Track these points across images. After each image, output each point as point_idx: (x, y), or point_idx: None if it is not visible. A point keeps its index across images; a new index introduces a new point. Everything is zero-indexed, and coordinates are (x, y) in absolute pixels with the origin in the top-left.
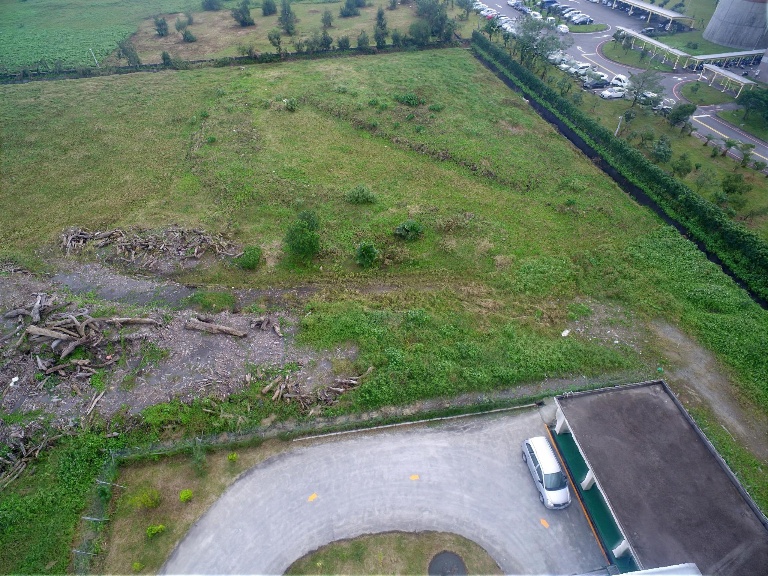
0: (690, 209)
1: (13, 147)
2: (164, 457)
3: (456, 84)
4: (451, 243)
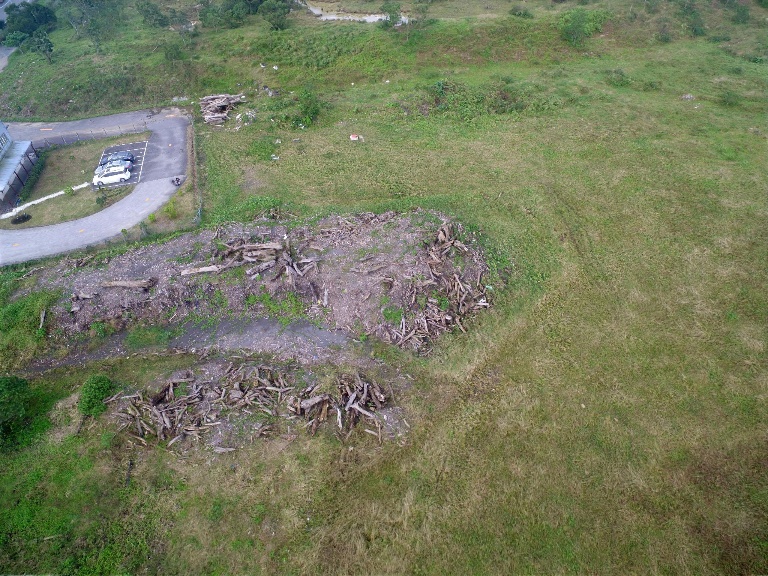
0: None
1: None
2: None
3: None
4: None
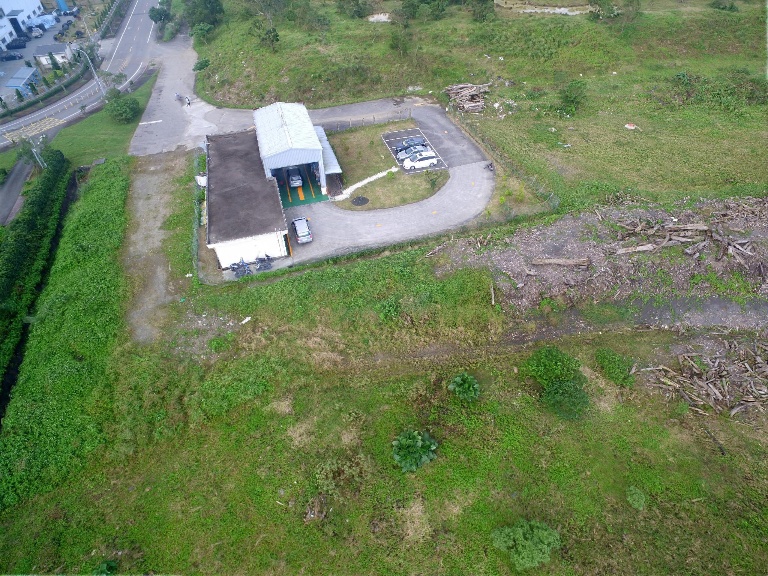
0: None
1: None
2: None
3: None
4: (349, 436)
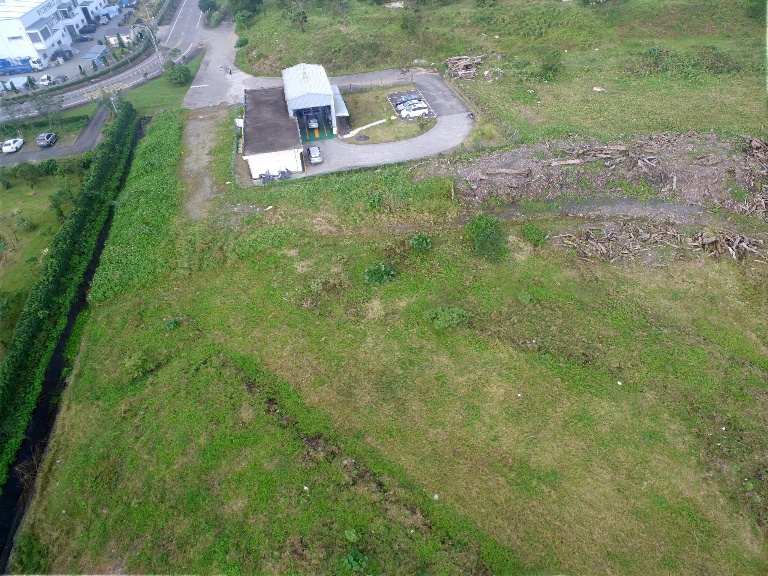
0: (48, 308)
1: None
2: None
3: None
4: (336, 269)
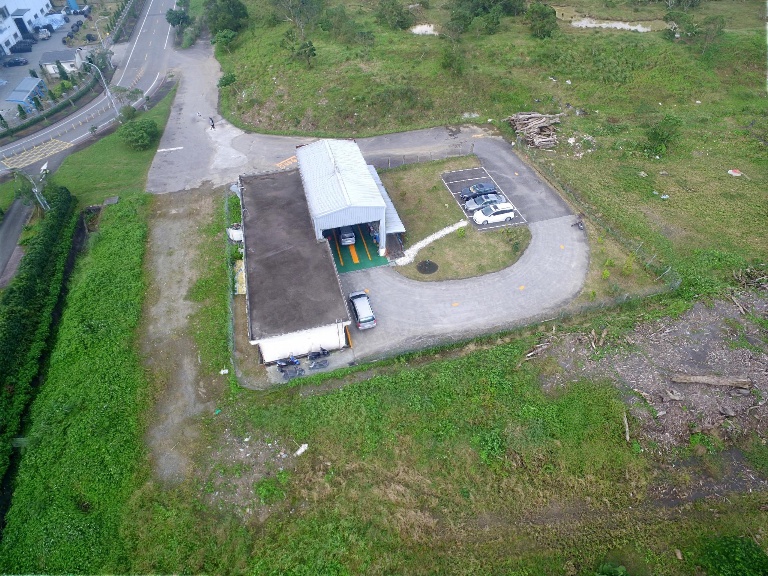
0: None
1: None
2: None
3: None
4: None
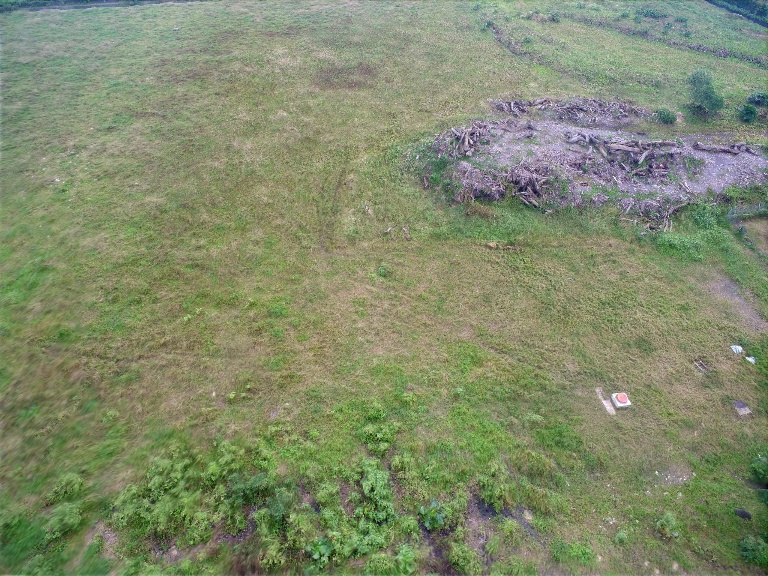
0: None
1: (348, 46)
2: (747, 218)
3: (675, 2)
4: None
